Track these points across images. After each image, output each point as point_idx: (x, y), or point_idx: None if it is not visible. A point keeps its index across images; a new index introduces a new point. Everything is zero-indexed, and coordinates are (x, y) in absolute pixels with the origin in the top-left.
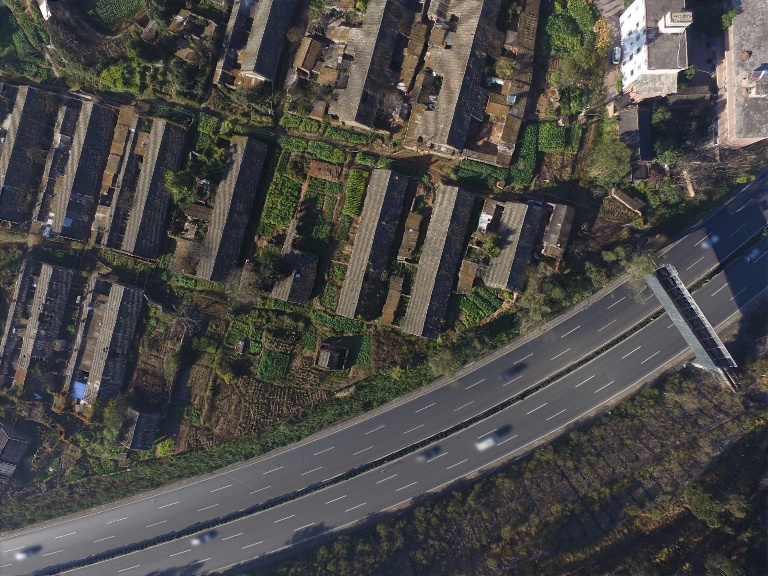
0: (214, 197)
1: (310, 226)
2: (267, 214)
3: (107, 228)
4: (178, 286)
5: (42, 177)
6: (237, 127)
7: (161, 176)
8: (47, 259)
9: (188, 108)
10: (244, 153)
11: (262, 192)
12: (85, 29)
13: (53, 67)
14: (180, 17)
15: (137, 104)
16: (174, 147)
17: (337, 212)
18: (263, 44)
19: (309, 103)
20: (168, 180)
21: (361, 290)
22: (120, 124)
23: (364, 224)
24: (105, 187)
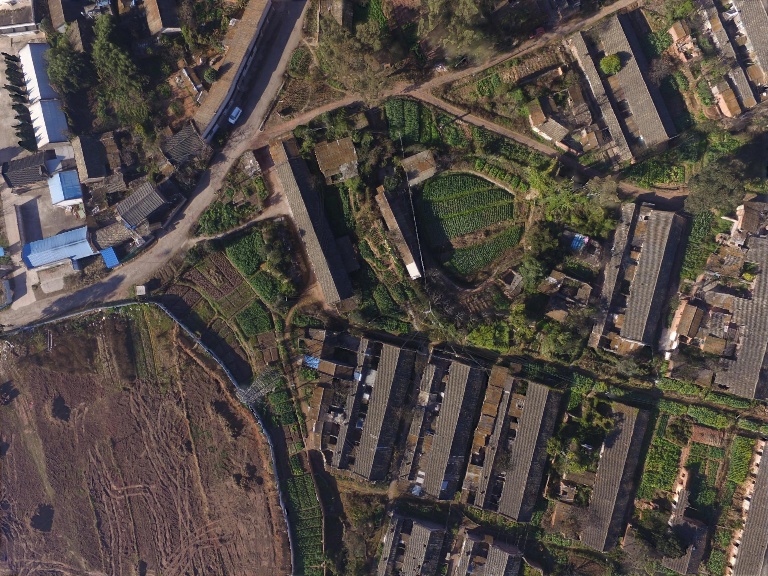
0: (596, 463)
1: (694, 492)
2: (649, 479)
3: (481, 489)
4: (551, 544)
5: (408, 434)
6: (614, 390)
7: (541, 441)
8: (410, 513)
9: (557, 366)
10: (634, 425)
11: (640, 454)
12: (445, 283)
13: (413, 321)
14: (553, 279)
15: (510, 365)
16: (552, 411)
17: (720, 477)
18: (649, 314)
19: (689, 368)
20: (552, 448)
21: (762, 566)
22: (493, 385)
23: (759, 497)
24: (476, 446)
